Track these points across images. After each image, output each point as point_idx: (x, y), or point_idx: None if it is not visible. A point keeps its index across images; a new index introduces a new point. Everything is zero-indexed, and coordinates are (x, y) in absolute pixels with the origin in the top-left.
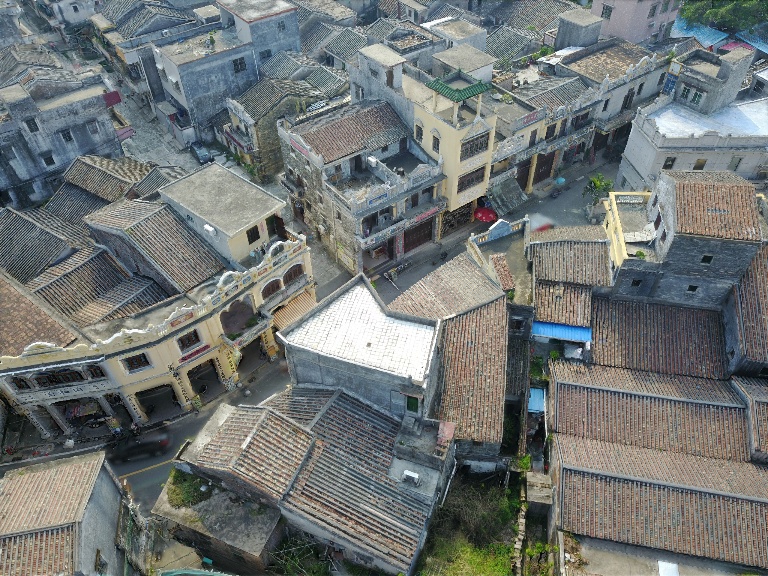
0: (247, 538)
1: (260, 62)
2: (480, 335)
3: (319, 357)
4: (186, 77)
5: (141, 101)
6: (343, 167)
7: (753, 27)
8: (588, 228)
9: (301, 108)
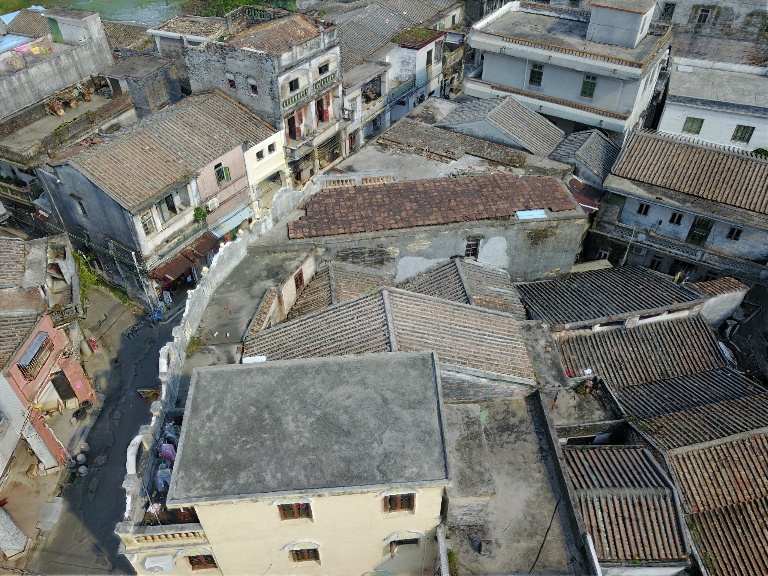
0: None
1: None
2: None
3: None
4: None
5: None
6: None
7: None
8: None
9: None
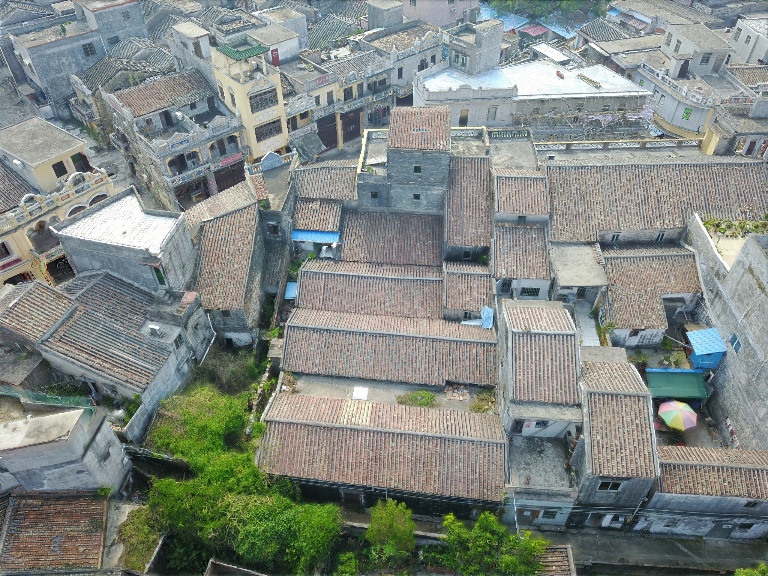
0: (12, 374)
1: (109, 47)
2: (233, 232)
3: (81, 242)
4: (37, 59)
5: (9, 88)
6: (154, 121)
7: (552, 14)
8: (351, 160)
9: (137, 82)
